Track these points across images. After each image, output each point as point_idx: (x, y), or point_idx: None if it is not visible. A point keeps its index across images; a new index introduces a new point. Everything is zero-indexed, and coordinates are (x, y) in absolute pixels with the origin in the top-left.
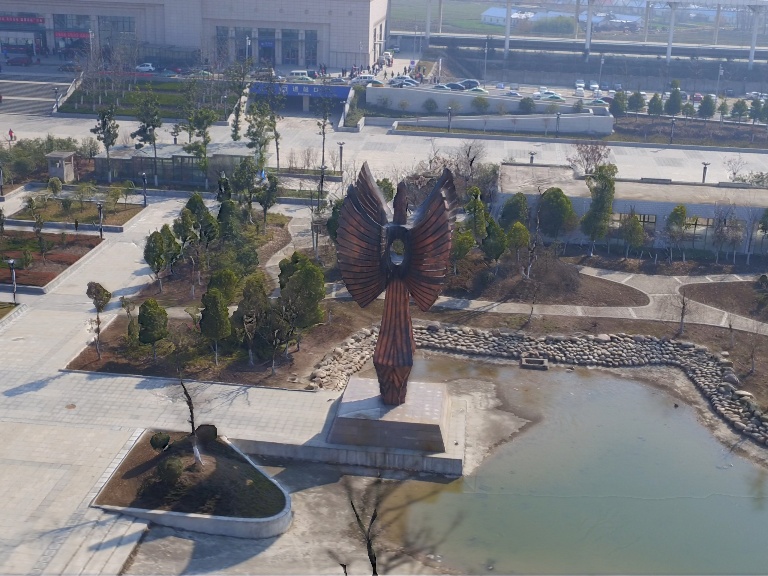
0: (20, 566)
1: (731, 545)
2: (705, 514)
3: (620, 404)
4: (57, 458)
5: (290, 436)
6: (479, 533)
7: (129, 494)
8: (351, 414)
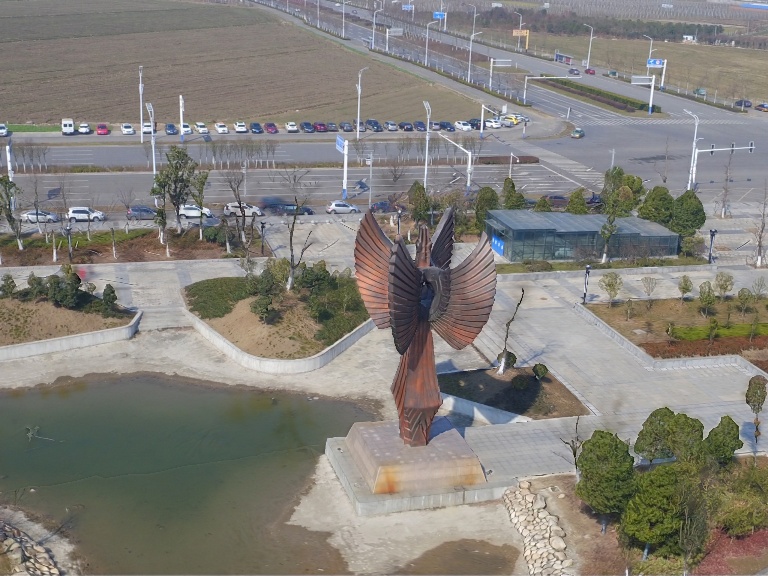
0: (529, 339)
1: (94, 447)
2: (110, 461)
3: (186, 573)
4: (616, 387)
5: (483, 432)
6: (292, 420)
7: (529, 370)
8: (436, 419)
